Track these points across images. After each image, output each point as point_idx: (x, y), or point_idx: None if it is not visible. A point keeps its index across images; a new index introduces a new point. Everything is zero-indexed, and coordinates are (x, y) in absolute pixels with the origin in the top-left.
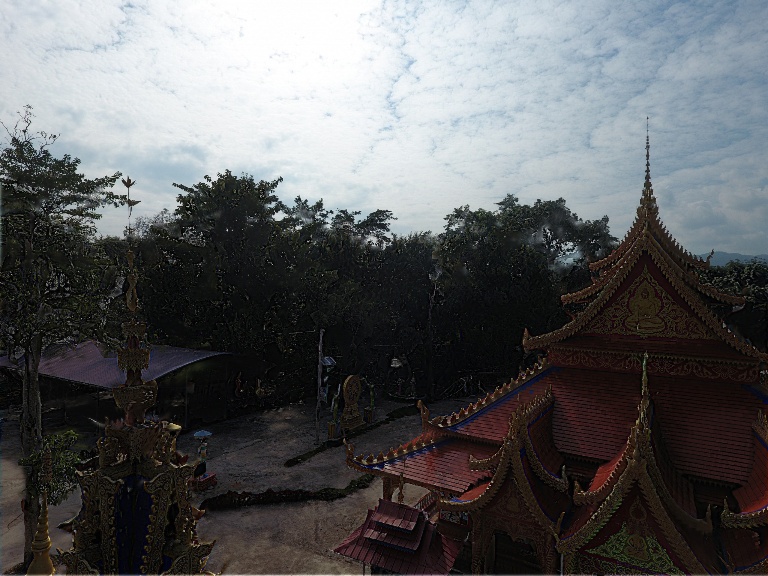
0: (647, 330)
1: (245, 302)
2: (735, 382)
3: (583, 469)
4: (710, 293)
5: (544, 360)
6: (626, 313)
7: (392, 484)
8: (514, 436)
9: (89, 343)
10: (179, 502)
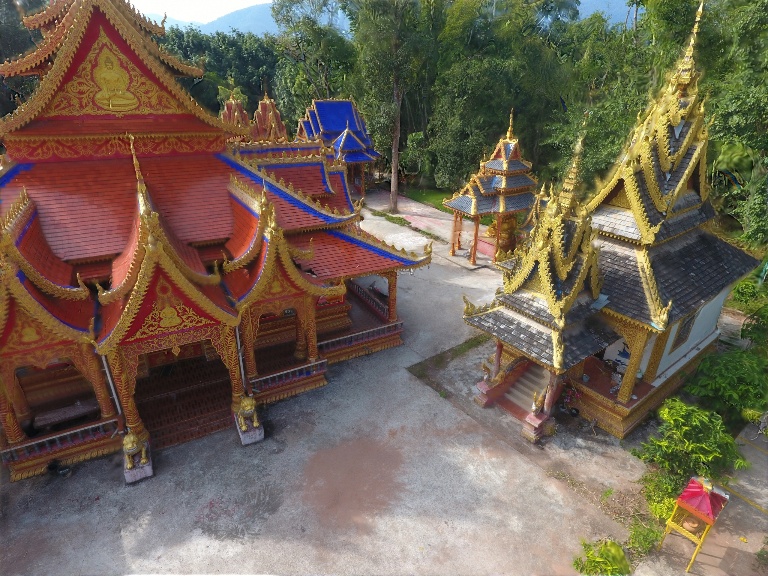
0: (121, 108)
1: None
2: (209, 153)
3: (96, 269)
4: (172, 64)
5: (2, 157)
6: (93, 88)
7: None
8: None
9: None
10: None
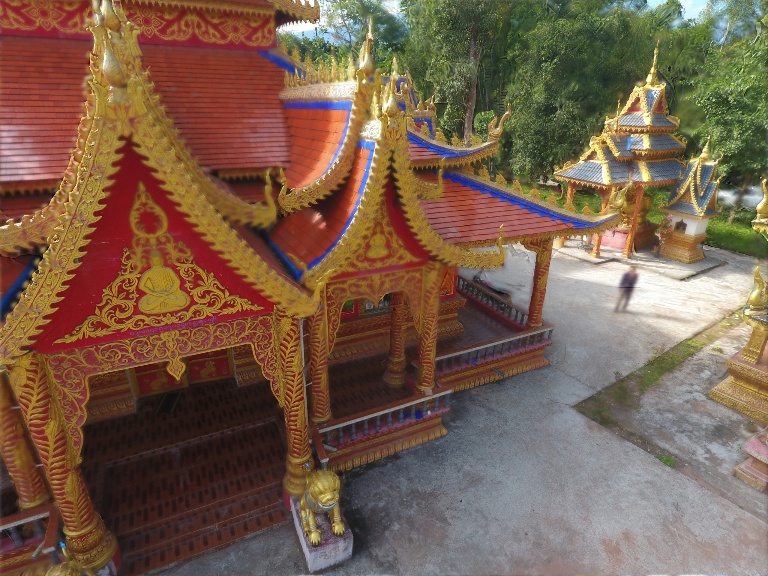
0: None
1: None
2: (250, 47)
3: (35, 206)
4: None
5: None
6: None
7: None
8: None
9: None
10: None
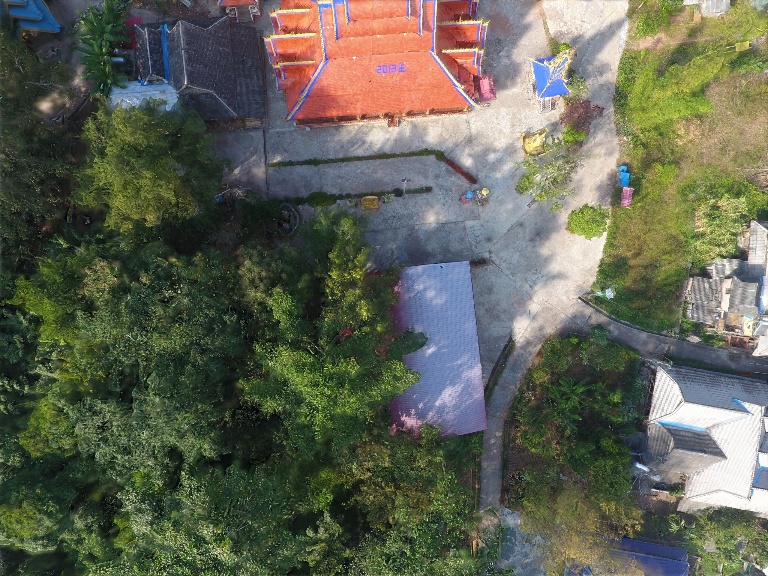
0: None
1: None
2: None
3: None
4: None
5: None
6: None
7: None
8: None
9: (440, 394)
10: None
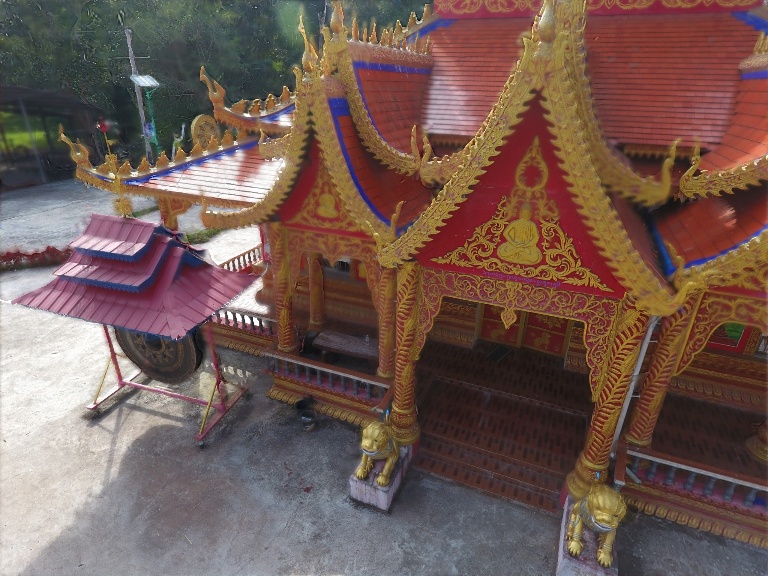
0: None
1: (40, 16)
2: (723, 8)
3: None
4: None
5: (426, 7)
6: None
7: (172, 210)
8: (325, 75)
9: None
10: None
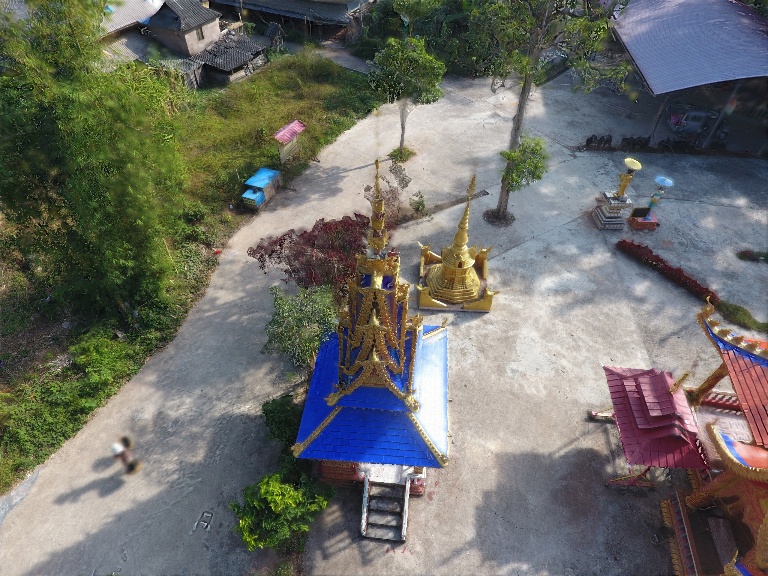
0: None
1: None
2: None
3: None
4: None
5: None
6: None
7: None
8: None
9: (687, 0)
10: (379, 302)
